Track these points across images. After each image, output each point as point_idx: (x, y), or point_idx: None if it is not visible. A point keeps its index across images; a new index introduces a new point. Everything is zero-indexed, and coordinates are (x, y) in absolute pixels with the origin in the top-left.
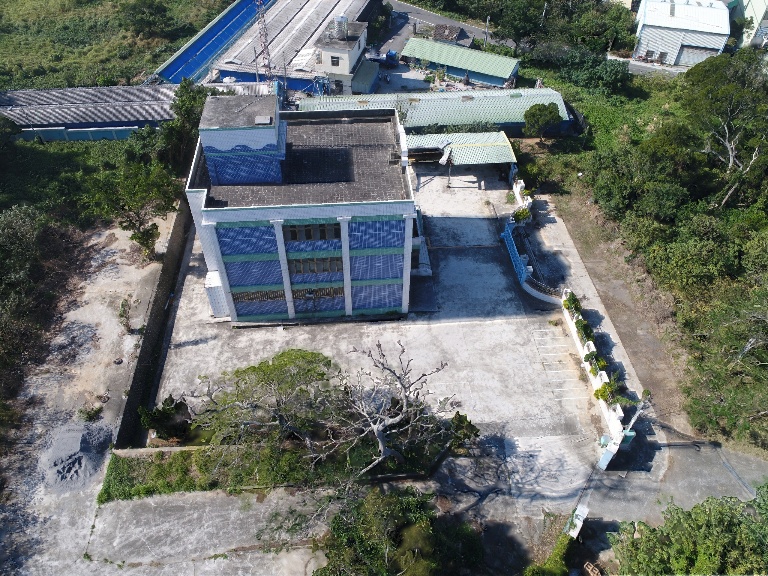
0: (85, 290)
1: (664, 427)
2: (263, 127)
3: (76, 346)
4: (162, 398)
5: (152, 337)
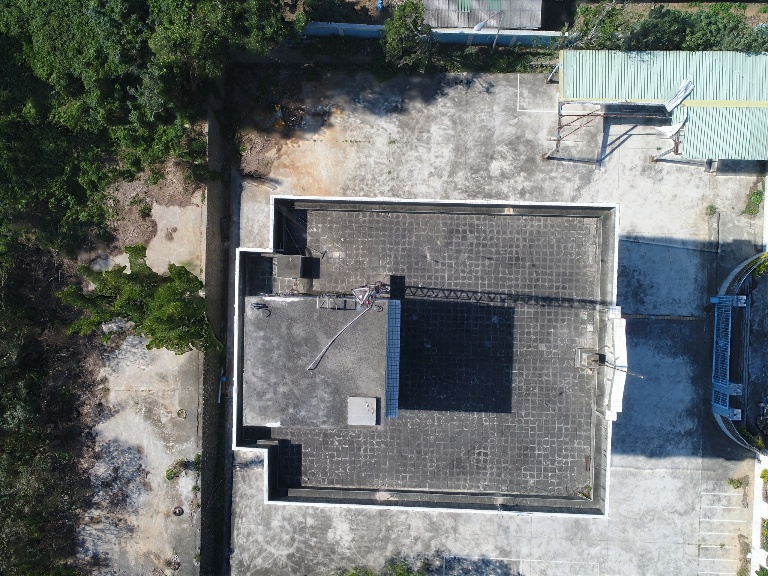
0: (108, 386)
1: None
2: (363, 429)
3: (122, 484)
4: (237, 544)
5: (211, 458)
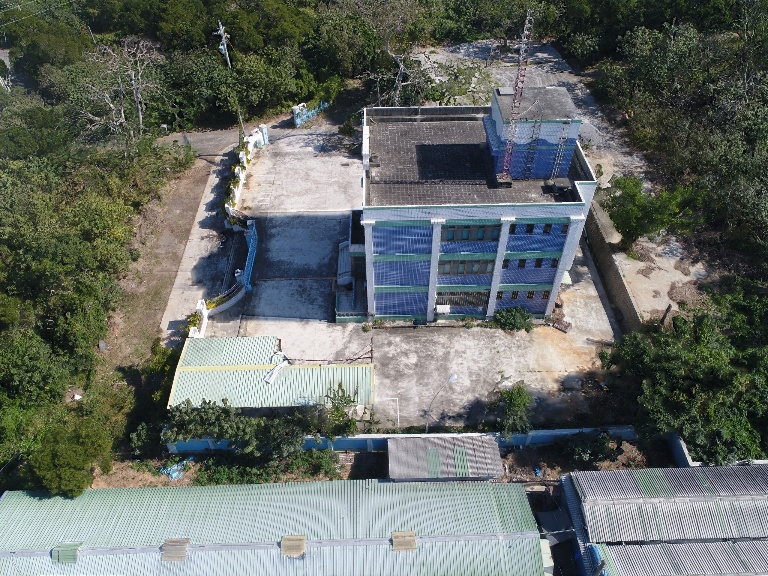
0: None
1: (212, 162)
2: None
3: None
4: None
5: None
